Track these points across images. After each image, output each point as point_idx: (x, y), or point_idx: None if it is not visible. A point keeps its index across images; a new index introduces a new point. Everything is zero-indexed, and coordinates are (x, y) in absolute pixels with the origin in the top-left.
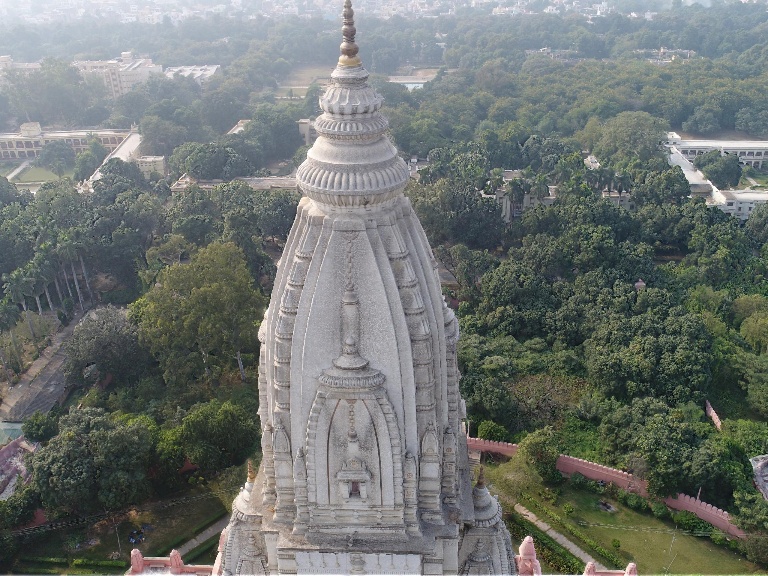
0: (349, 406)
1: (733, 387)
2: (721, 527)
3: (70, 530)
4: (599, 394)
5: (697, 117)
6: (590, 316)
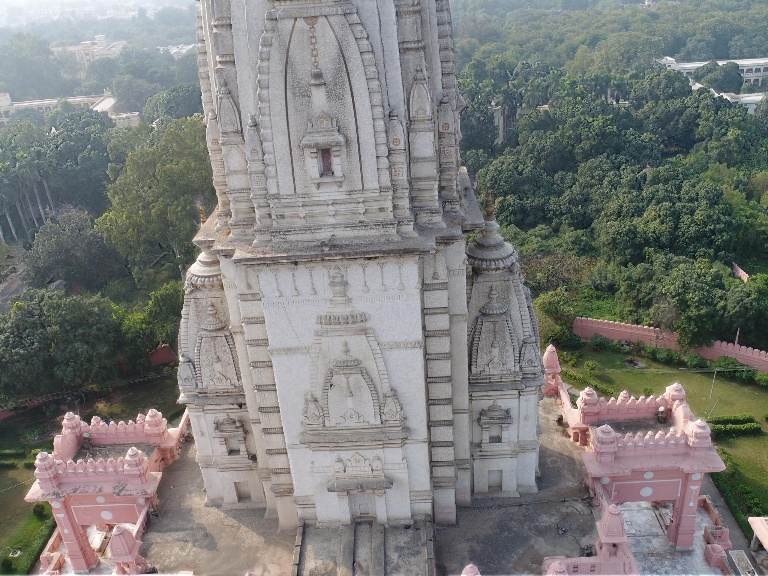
0: (309, 29)
1: (760, 253)
2: (765, 372)
3: (29, 425)
4: (614, 268)
5: (689, 48)
6: (597, 197)
